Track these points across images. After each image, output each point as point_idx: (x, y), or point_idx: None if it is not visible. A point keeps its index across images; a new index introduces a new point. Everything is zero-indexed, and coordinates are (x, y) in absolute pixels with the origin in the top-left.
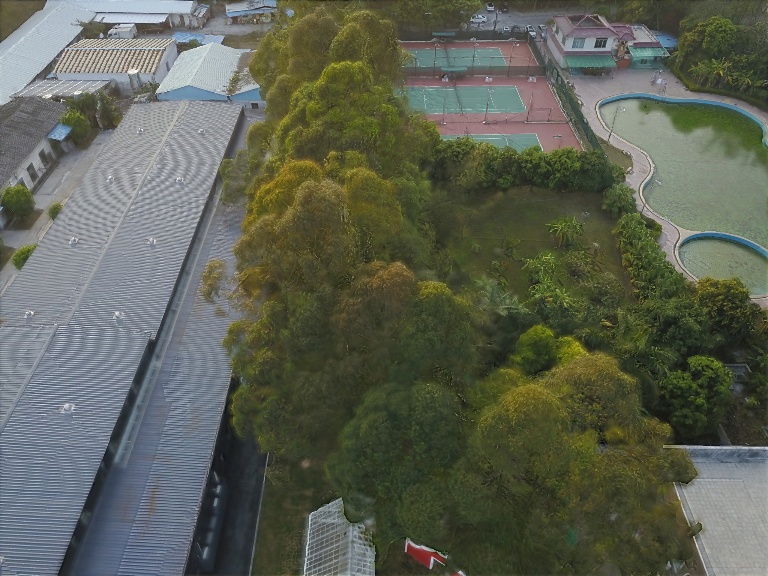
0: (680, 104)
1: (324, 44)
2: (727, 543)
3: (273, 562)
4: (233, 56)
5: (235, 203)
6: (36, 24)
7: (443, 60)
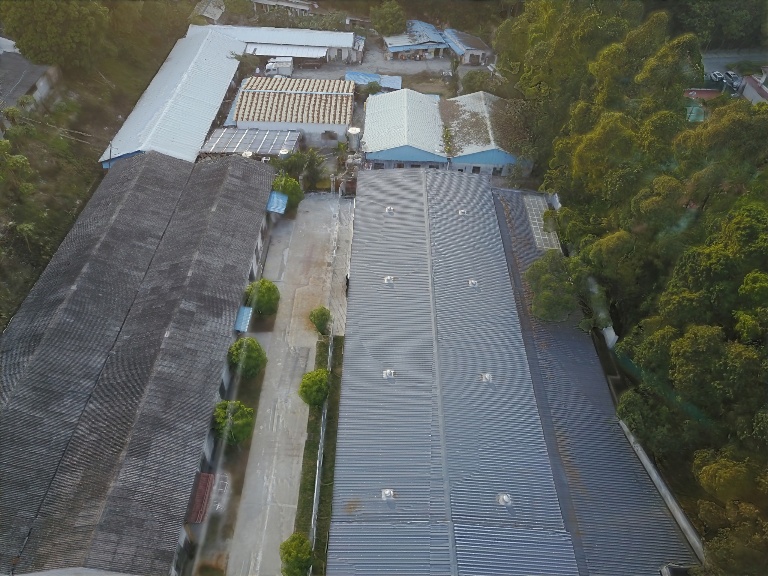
0: None
1: (764, 151)
2: None
3: None
4: (432, 106)
5: (555, 319)
6: (193, 57)
7: None
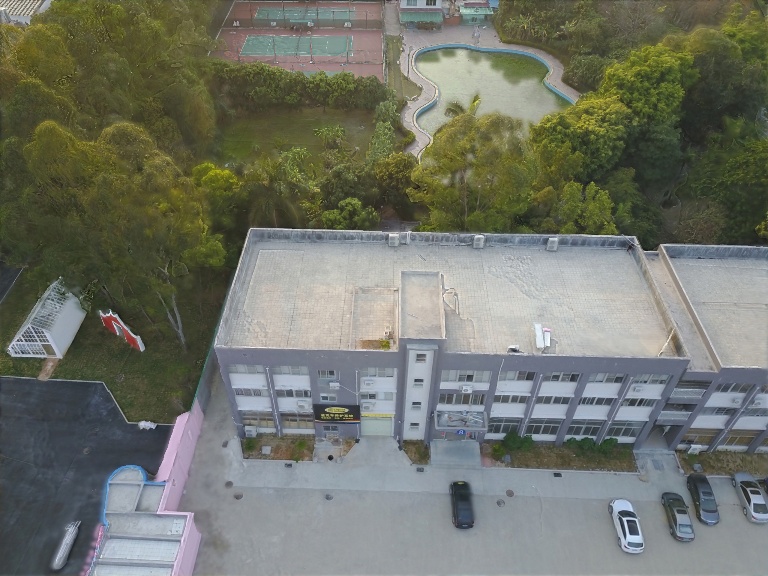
0: (490, 53)
1: None
2: (267, 280)
3: (3, 328)
4: None
5: None
6: None
7: (300, 16)
